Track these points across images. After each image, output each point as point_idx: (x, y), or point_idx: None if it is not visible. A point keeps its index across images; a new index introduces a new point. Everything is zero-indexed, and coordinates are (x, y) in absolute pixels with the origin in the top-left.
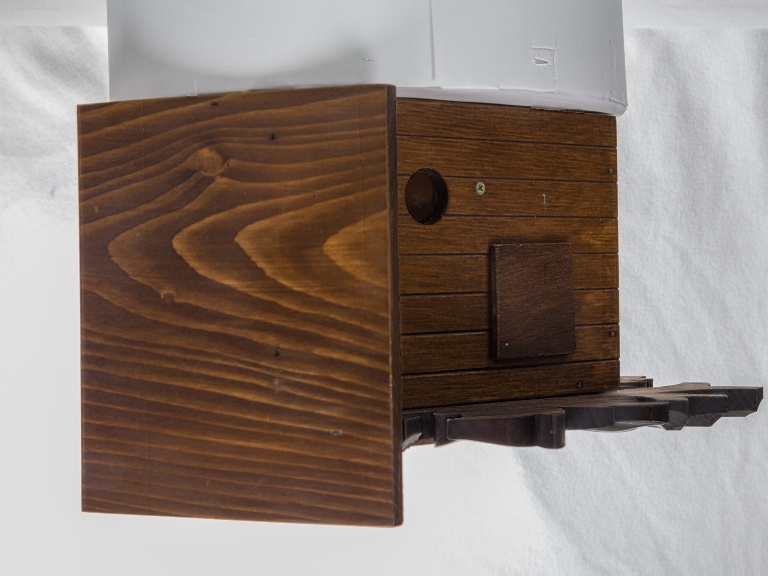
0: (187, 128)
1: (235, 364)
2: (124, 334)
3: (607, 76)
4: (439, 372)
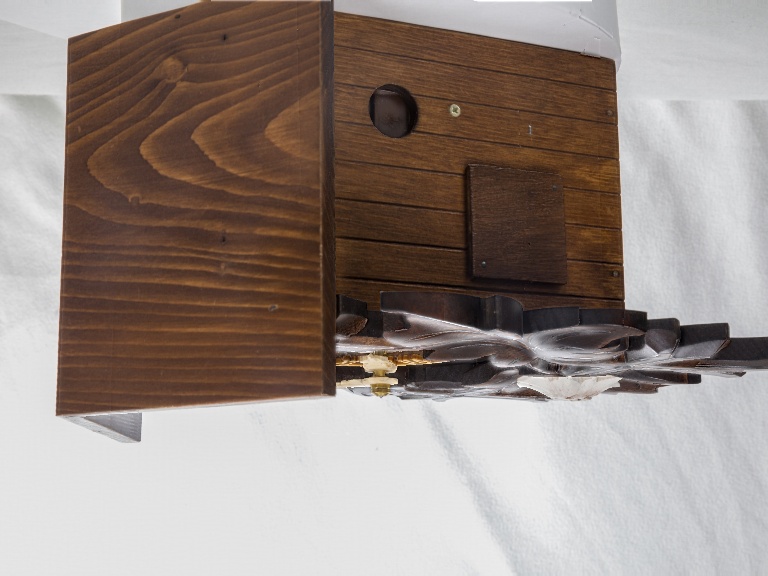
0: (155, 42)
1: (188, 254)
2: (97, 241)
3: None
4: (407, 283)
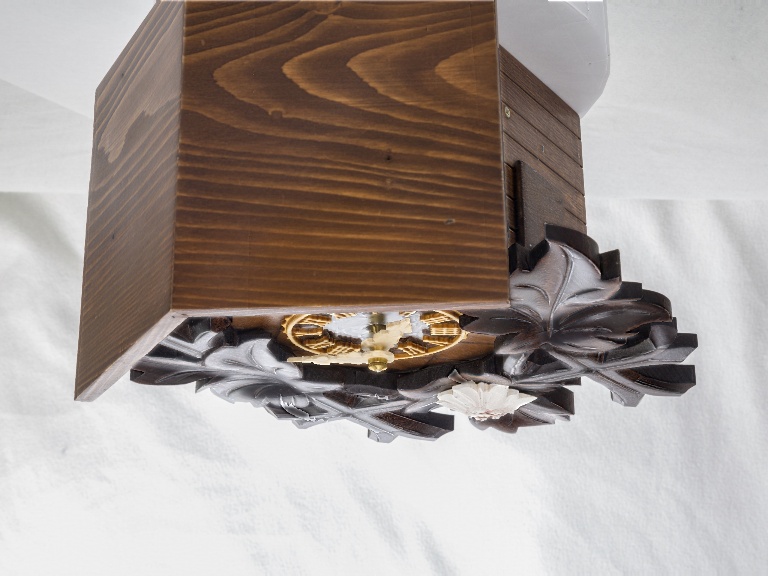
0: None
1: (346, 168)
2: (228, 147)
3: None
4: None
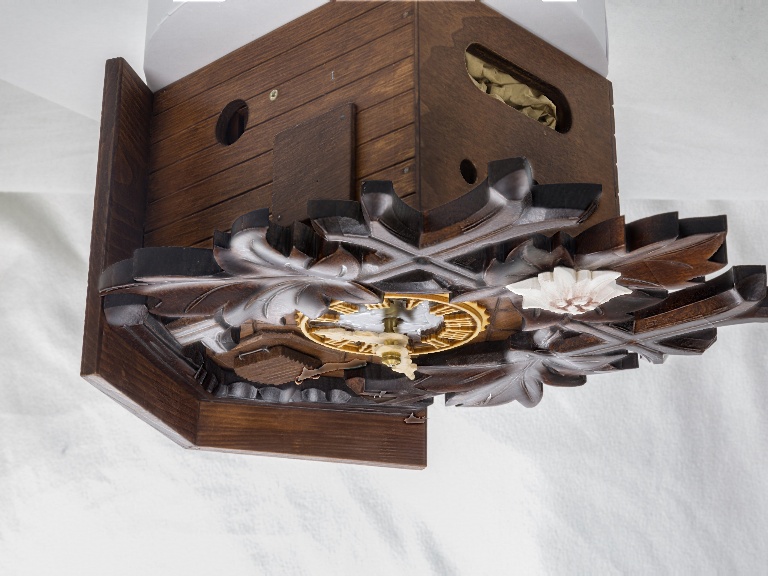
0: None
1: None
2: None
3: None
4: None
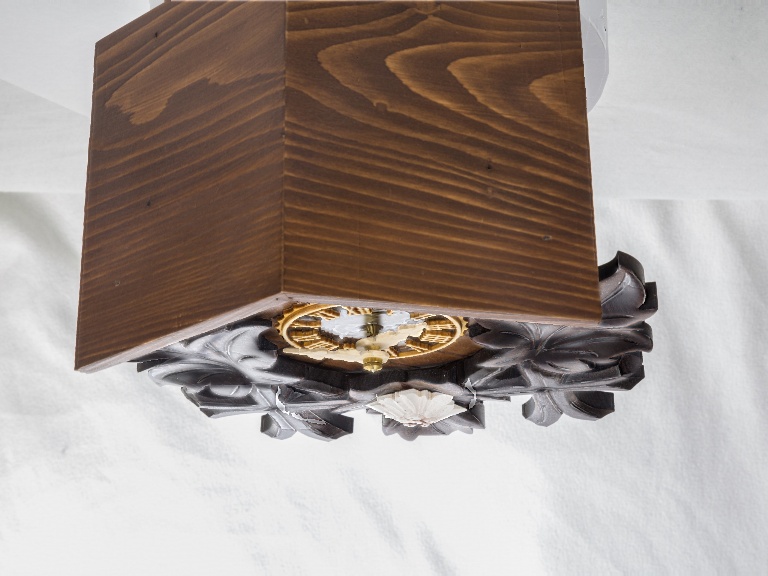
0: None
1: (449, 171)
2: (334, 132)
3: None
4: None
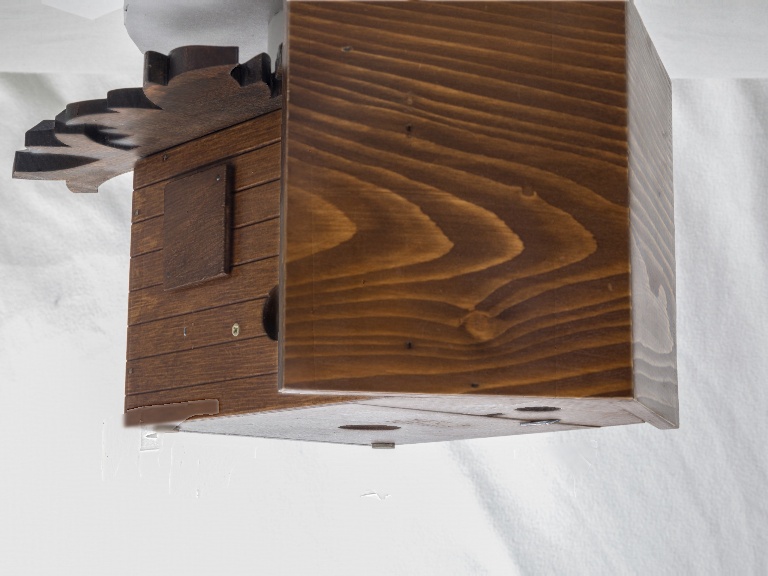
0: (506, 363)
1: (455, 121)
2: (578, 158)
3: (105, 439)
4: (276, 143)
